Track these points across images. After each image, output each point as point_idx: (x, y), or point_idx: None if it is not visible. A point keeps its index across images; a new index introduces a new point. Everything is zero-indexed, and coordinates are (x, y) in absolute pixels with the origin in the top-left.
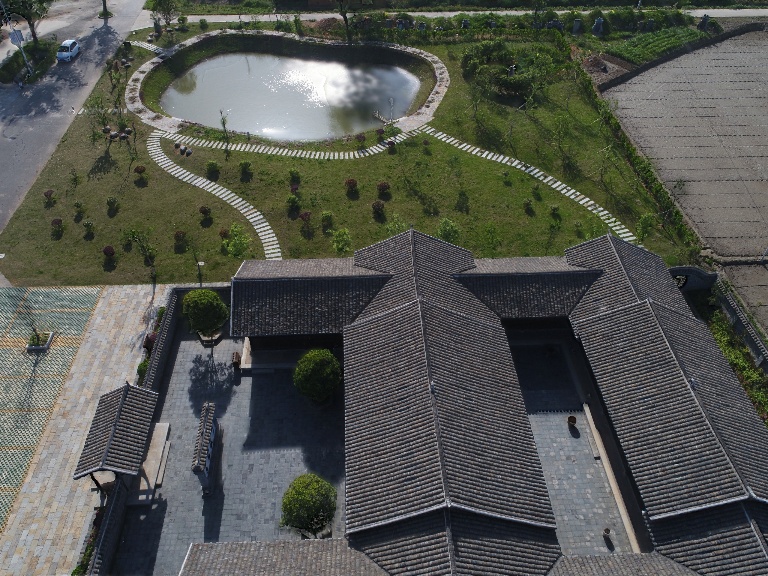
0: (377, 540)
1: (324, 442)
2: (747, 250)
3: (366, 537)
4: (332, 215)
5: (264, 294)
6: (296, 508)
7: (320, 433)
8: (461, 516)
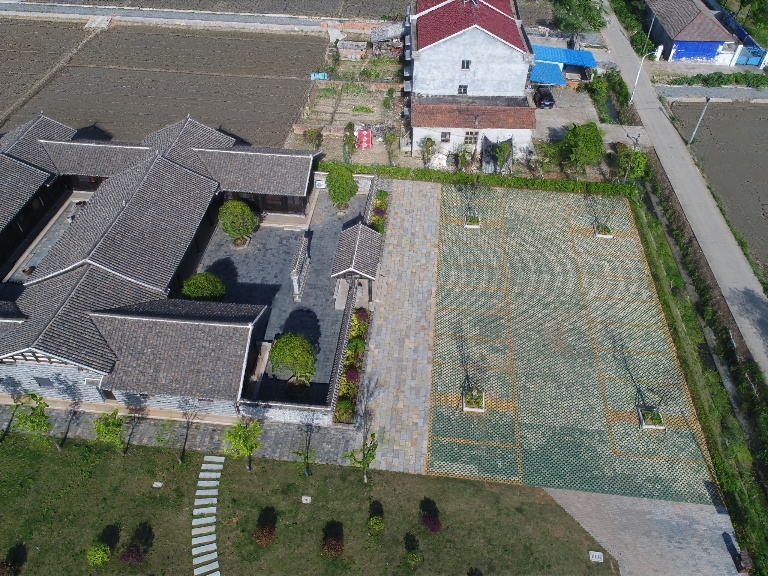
0: None
1: None
2: None
3: None
4: (87, 575)
5: (224, 318)
6: None
7: None
8: None
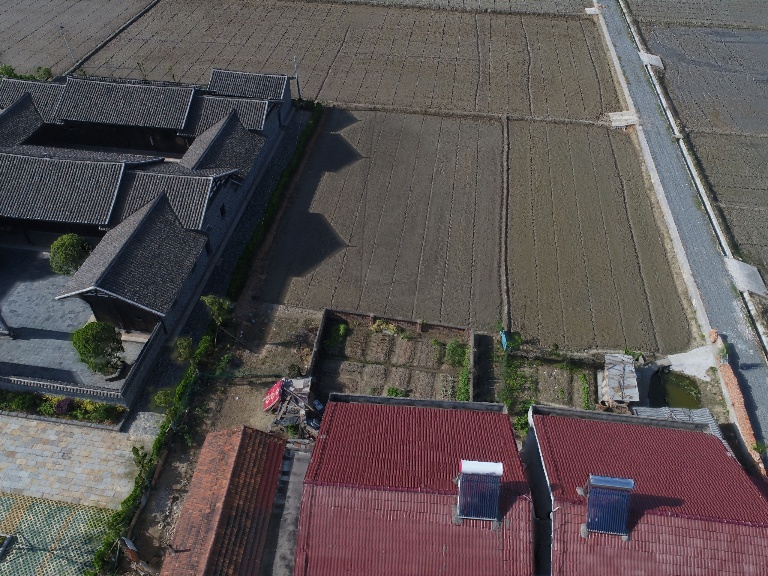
0: (121, 211)
1: (27, 270)
2: (64, 68)
3: (115, 217)
4: None
5: None
6: (72, 249)
7: (17, 271)
8: (133, 169)
